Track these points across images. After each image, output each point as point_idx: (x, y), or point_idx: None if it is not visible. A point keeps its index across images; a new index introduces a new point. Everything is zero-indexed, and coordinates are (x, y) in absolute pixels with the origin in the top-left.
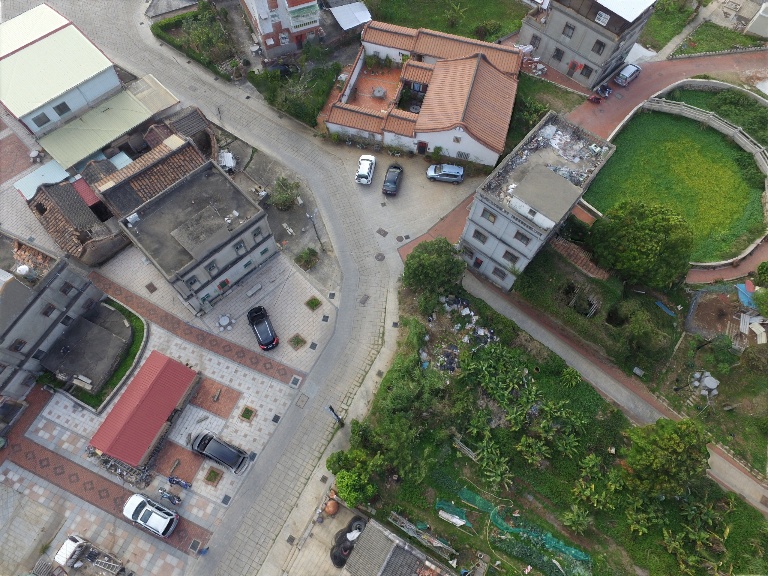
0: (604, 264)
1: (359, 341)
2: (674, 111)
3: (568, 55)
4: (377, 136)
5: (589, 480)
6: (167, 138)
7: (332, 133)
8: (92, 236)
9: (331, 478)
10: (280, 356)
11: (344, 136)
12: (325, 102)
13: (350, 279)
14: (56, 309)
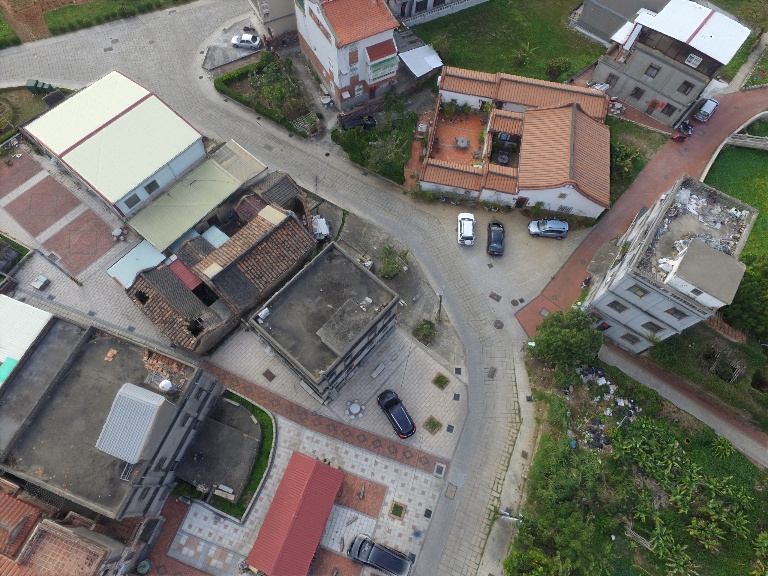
0: (741, 325)
1: (496, 420)
2: (758, 146)
3: (649, 94)
4: (474, 193)
5: (763, 559)
6: (262, 210)
7: (427, 192)
8: (203, 325)
9: (498, 575)
10: (418, 443)
11: (439, 194)
12: (411, 157)
13: (473, 351)
14: (190, 417)
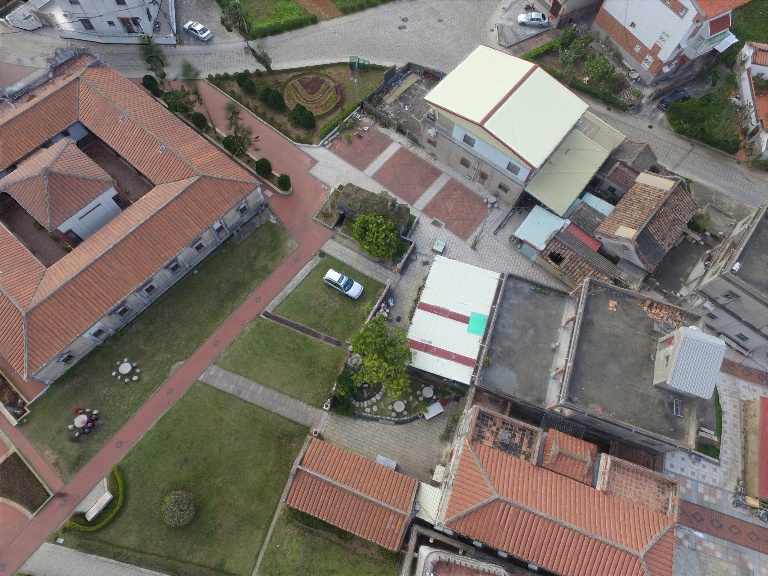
0: None
1: None
2: None
3: None
4: None
5: None
6: (638, 177)
7: None
8: (627, 283)
9: None
10: None
11: None
12: None
13: None
14: None
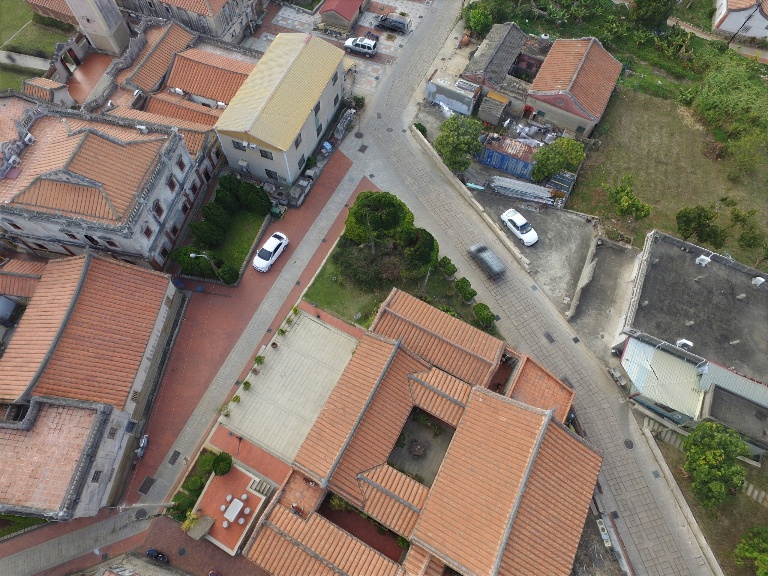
0: None
1: None
2: None
3: None
4: None
5: None
6: None
7: None
8: None
9: None
10: None
11: None
12: None
13: None
14: None
